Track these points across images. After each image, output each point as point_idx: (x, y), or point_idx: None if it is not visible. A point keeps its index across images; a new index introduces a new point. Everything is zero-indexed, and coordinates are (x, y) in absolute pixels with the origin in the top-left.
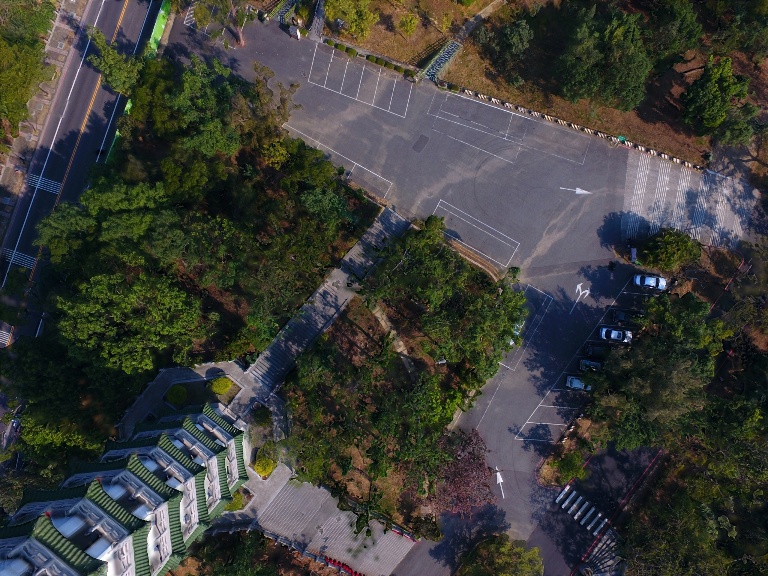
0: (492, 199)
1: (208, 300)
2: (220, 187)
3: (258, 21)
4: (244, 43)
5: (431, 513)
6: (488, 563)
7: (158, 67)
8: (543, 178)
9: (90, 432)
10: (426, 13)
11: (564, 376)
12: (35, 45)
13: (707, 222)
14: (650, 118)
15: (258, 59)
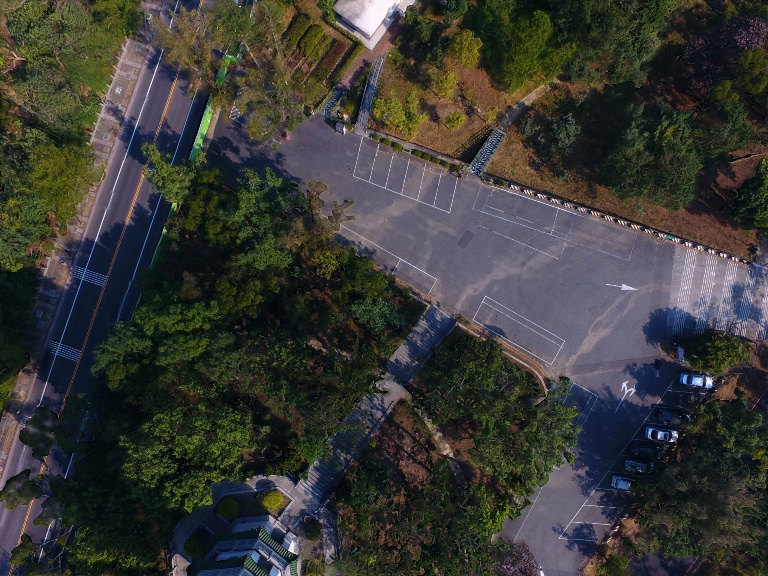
0: (537, 296)
1: (256, 405)
2: (271, 298)
3: (303, 115)
4: (289, 138)
5: None
6: None
7: (210, 178)
8: (589, 274)
9: (145, 552)
10: (469, 101)
11: (609, 475)
12: (81, 138)
13: (753, 316)
14: (695, 209)
15: (303, 153)
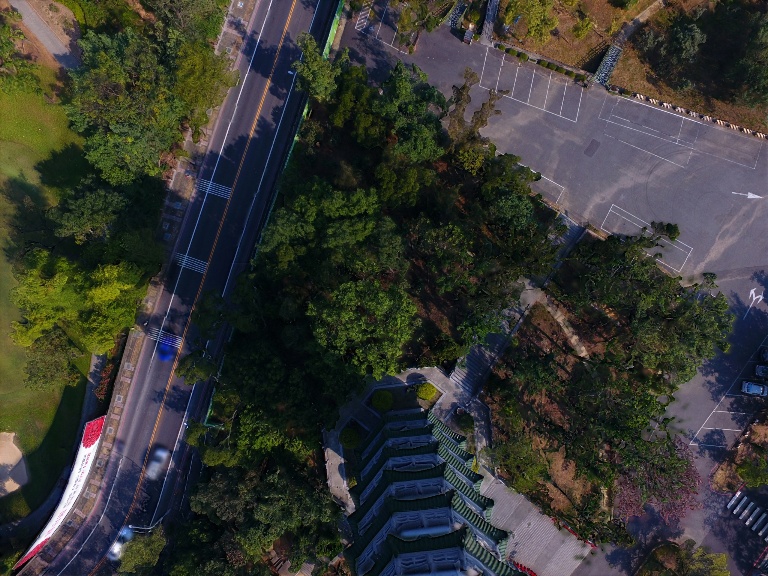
0: (664, 204)
1: None
2: (420, 193)
3: None
4: (416, 48)
5: (617, 518)
6: (677, 569)
7: (360, 73)
8: (715, 183)
9: (309, 437)
10: (587, 17)
11: (739, 381)
12: None
13: None
14: None
15: (429, 64)
